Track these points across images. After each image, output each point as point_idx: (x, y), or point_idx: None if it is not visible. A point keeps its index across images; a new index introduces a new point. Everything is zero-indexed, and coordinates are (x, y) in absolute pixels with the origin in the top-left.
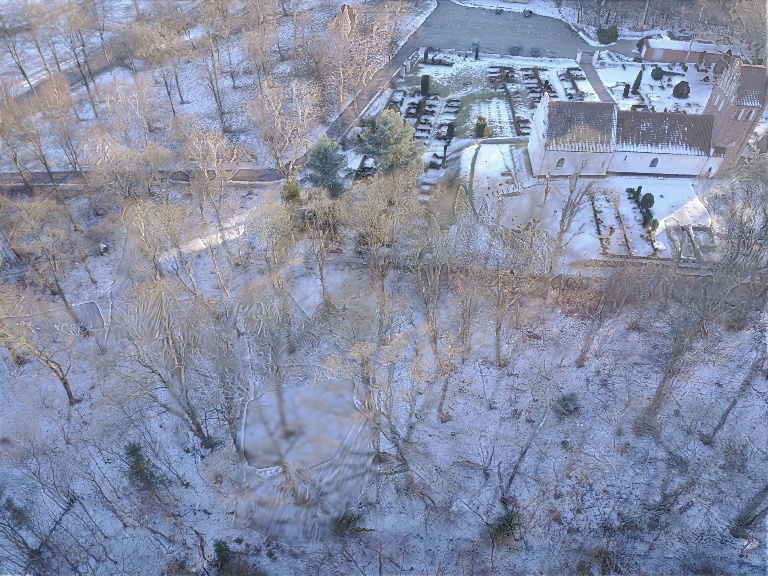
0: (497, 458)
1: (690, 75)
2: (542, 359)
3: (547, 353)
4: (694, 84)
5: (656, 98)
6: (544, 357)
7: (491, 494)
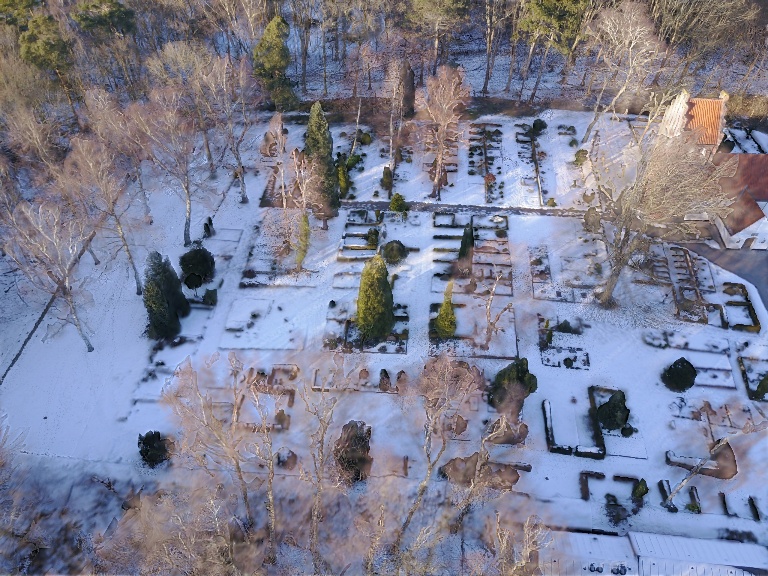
0: (766, 72)
1: (652, 468)
2: (767, 84)
3: (765, 85)
4: (649, 421)
5: (721, 365)
6: (766, 84)
7: (762, 66)
